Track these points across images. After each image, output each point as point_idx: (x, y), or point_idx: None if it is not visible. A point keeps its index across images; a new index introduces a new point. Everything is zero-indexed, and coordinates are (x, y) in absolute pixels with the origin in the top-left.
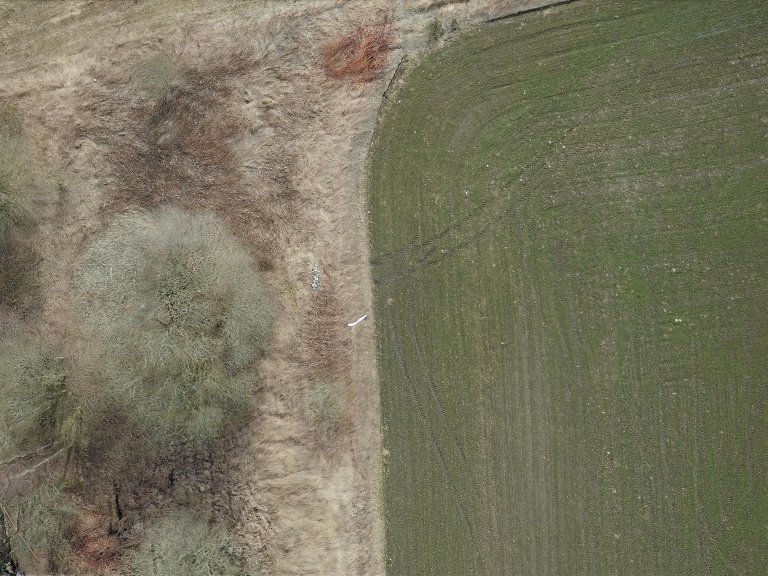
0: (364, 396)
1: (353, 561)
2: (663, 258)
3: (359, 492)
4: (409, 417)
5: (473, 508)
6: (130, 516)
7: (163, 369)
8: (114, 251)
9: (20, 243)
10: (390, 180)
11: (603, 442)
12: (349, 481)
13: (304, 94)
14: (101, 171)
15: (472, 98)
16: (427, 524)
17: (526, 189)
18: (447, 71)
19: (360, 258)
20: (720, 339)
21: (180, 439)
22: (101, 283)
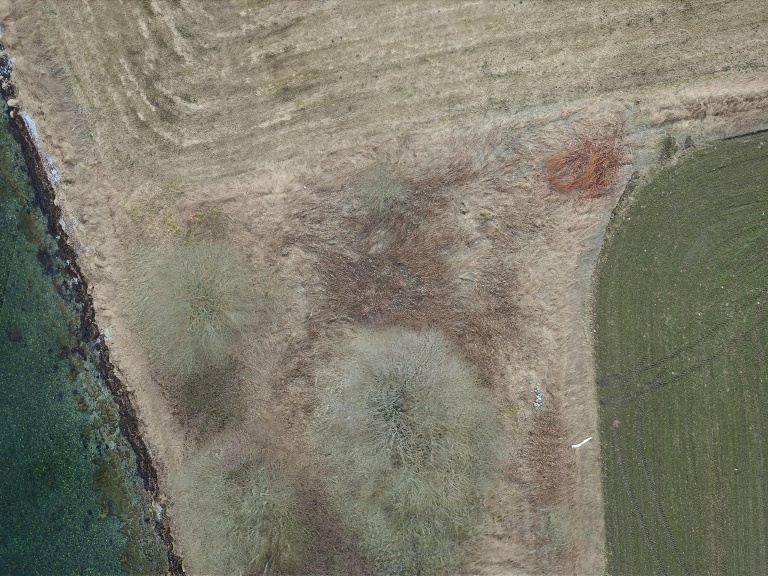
0: (588, 520)
1: None
2: None
3: None
4: (635, 542)
5: None
6: None
7: (412, 507)
8: (320, 361)
9: (221, 350)
10: (618, 299)
11: None
12: None
13: (525, 207)
14: (309, 280)
15: (706, 217)
16: None
17: (764, 313)
18: (680, 189)
19: (585, 378)
20: None
21: (387, 555)
22: (305, 393)
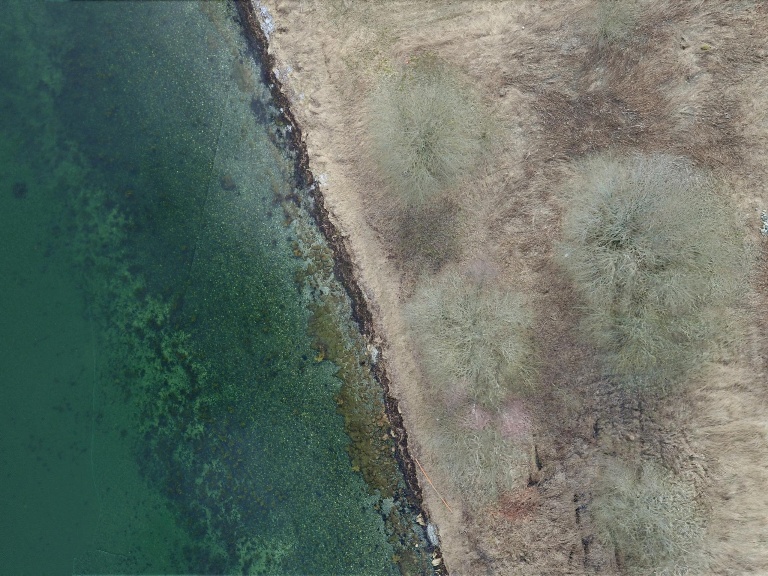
0: None
1: None
2: None
3: None
4: None
5: None
6: (551, 466)
7: (675, 308)
8: (537, 200)
9: (435, 193)
10: None
11: None
12: None
13: (747, 39)
14: (526, 119)
15: None
16: None
17: None
18: None
19: None
20: None
21: (606, 388)
22: (522, 232)
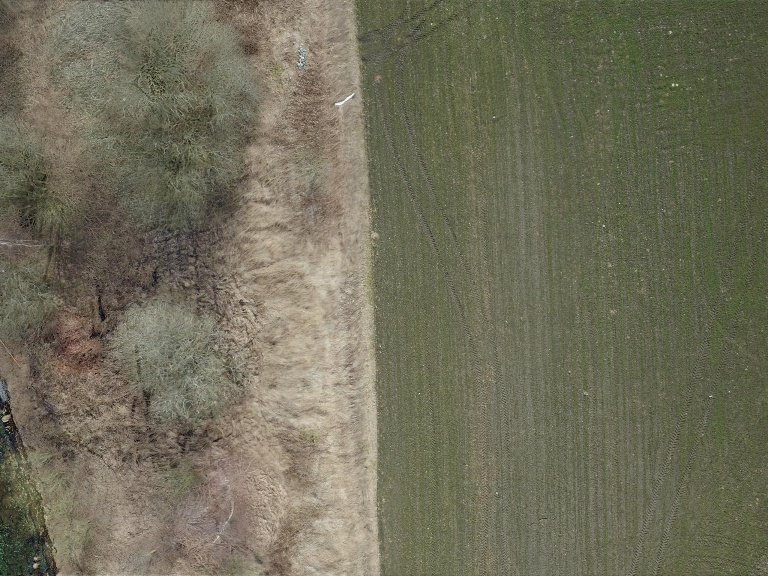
0: (352, 177)
1: (341, 349)
2: (659, 20)
3: (347, 277)
4: (398, 198)
5: (464, 289)
6: (113, 317)
7: (142, 120)
8: (95, 43)
9: None
10: None
11: (598, 215)
12: (337, 266)
13: None
14: None
15: None
16: (417, 308)
17: None
18: None
19: (347, 35)
20: (718, 103)
21: (164, 235)
22: (82, 77)
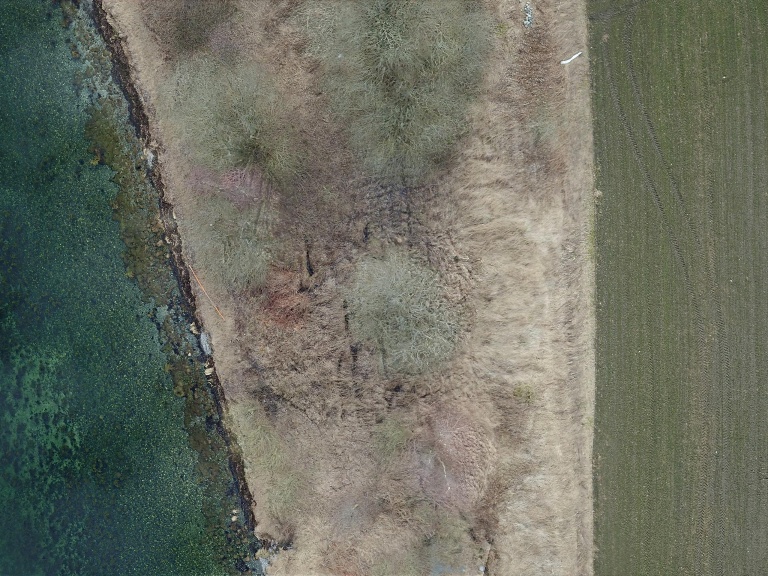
0: (576, 136)
1: (561, 306)
2: None
3: (569, 234)
4: (623, 156)
5: (689, 248)
6: (322, 272)
7: (400, 69)
8: None
9: None
10: None
11: None
12: (559, 223)
13: None
14: None
15: None
16: (640, 266)
17: None
18: None
19: None
20: None
21: (376, 191)
22: (297, 33)
